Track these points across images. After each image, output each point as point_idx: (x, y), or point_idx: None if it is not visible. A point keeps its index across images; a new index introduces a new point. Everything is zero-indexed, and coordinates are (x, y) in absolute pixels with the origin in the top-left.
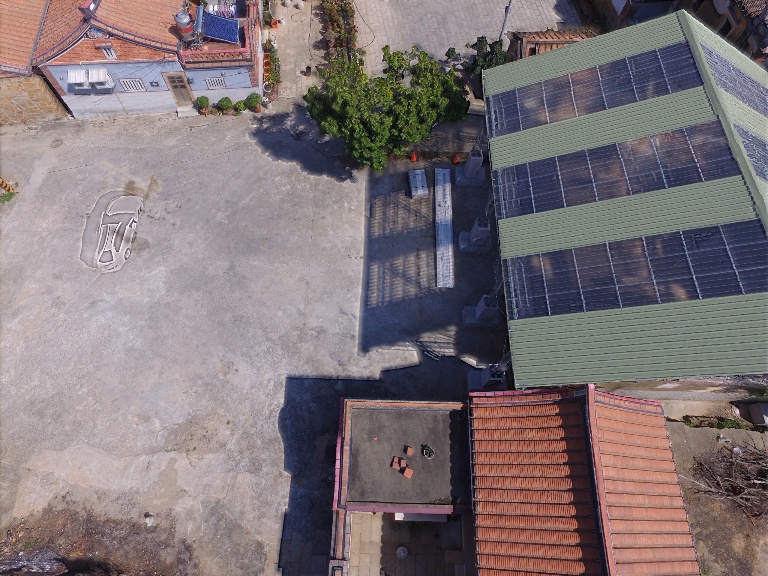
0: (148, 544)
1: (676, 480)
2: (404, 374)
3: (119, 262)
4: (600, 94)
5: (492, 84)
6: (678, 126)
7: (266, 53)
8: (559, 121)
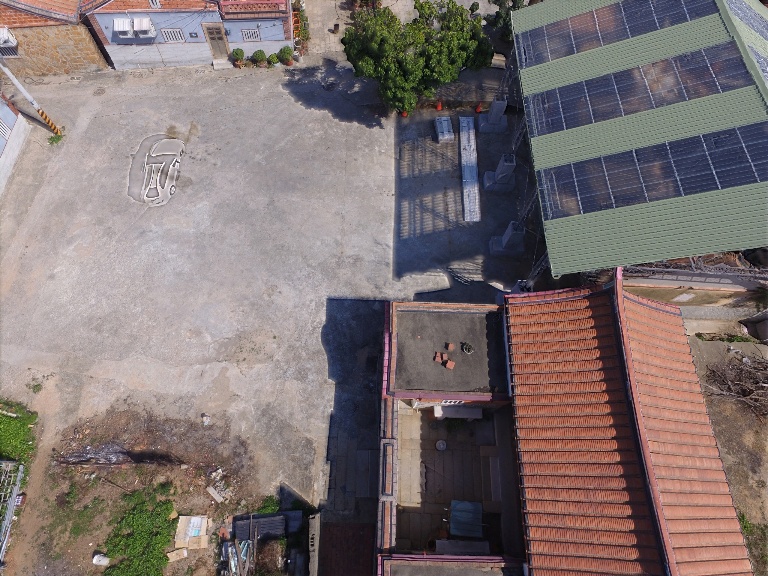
0: (206, 440)
1: (694, 370)
2: (436, 296)
3: (165, 197)
4: (623, 25)
5: (521, 23)
6: (697, 48)
7: (295, 12)
8: (586, 51)
